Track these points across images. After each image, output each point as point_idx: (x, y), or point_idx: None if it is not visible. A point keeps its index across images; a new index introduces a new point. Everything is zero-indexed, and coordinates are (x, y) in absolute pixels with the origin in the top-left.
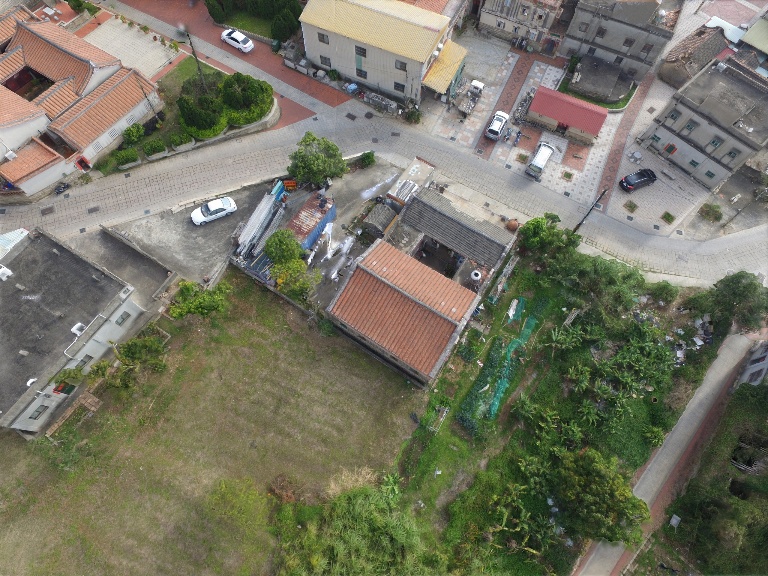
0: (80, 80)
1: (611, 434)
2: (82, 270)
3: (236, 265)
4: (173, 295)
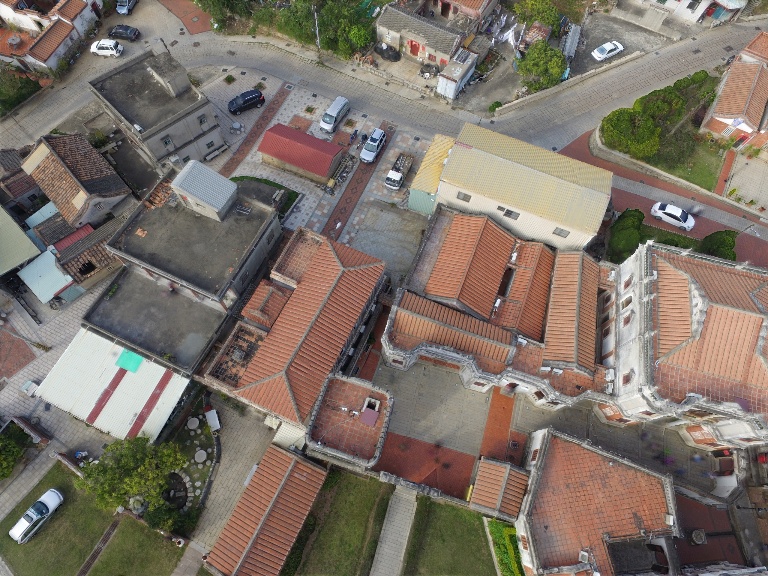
0: None
1: None
2: None
3: None
4: (608, 5)
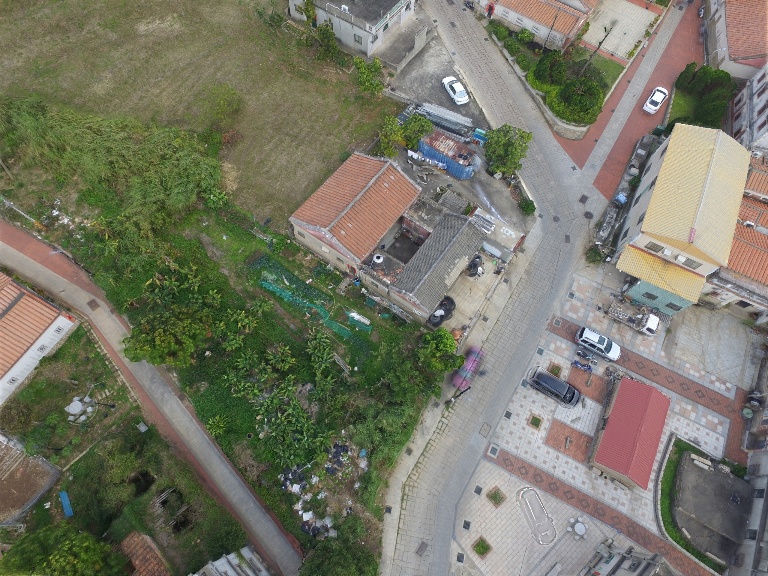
0: None
1: None
2: (390, 8)
3: (407, 107)
4: None
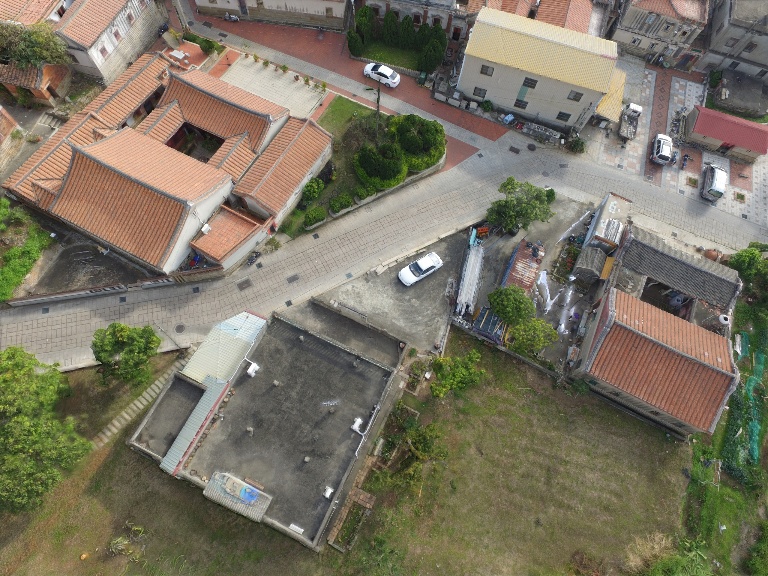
0: (256, 136)
1: None
2: (333, 356)
3: (459, 326)
4: (409, 367)
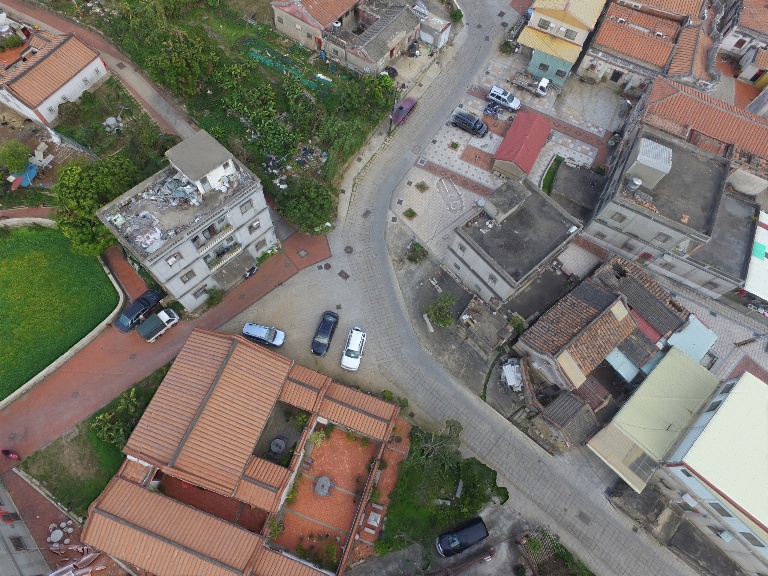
0: None
1: (222, 104)
2: None
3: None
4: None
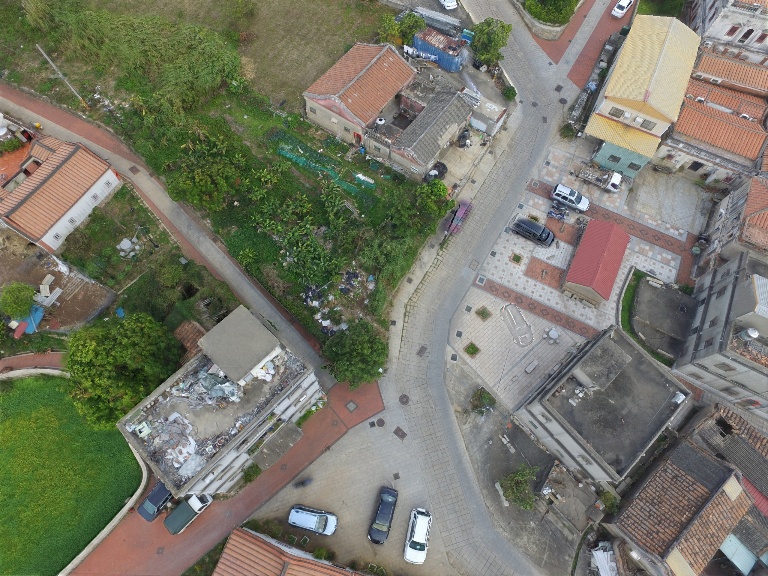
0: None
1: None
2: None
3: None
4: None
